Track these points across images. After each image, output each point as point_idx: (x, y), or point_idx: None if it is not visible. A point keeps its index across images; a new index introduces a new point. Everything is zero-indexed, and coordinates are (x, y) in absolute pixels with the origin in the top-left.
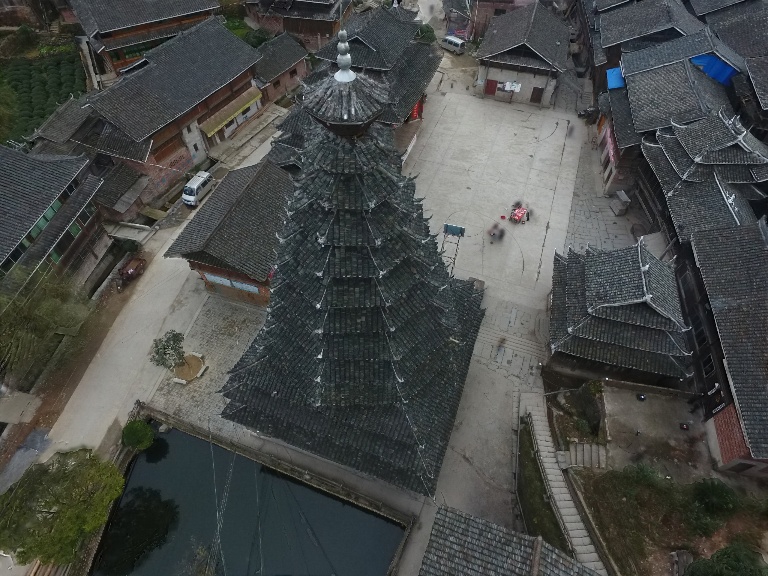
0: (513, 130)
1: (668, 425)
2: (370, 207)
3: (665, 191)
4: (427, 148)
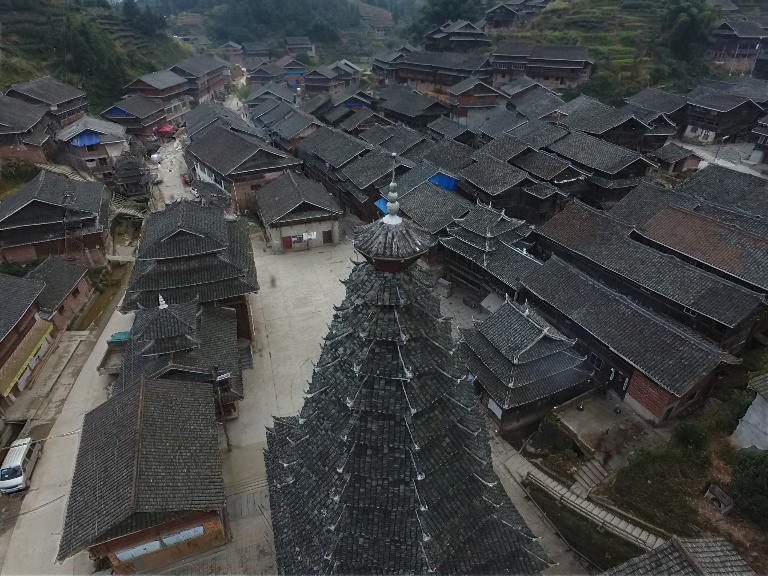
0: (327, 268)
1: (609, 416)
2: (439, 323)
3: (480, 263)
4: (266, 309)
